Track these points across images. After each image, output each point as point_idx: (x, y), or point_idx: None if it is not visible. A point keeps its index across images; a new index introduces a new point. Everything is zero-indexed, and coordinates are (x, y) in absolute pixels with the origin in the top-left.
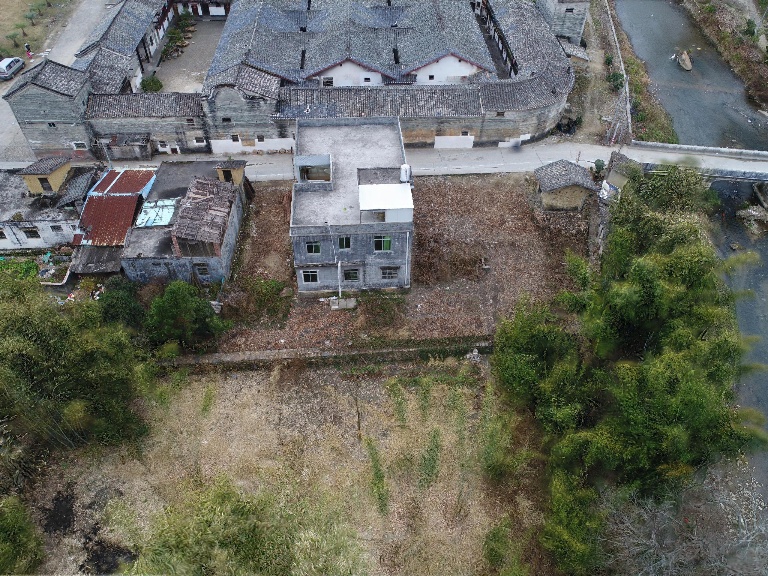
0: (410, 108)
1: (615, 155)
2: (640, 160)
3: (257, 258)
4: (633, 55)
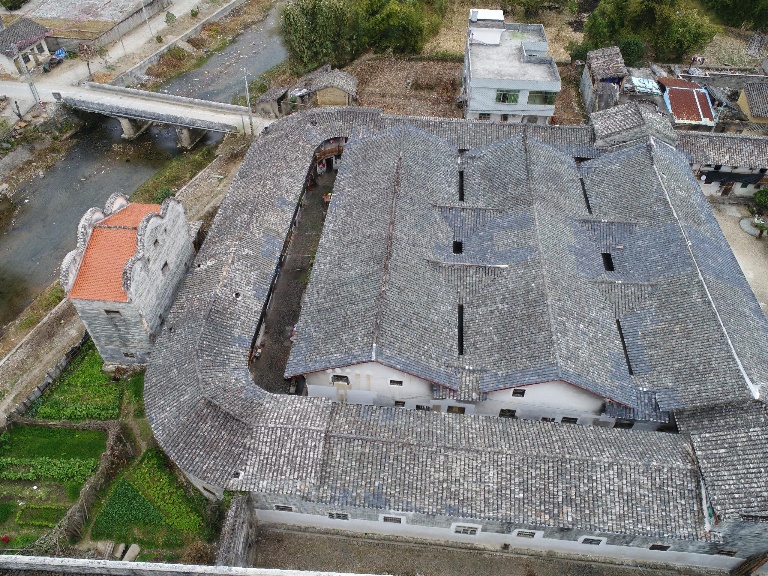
0: (454, 119)
1: (278, 95)
2: (241, 121)
3: (565, 91)
4: (5, 342)
